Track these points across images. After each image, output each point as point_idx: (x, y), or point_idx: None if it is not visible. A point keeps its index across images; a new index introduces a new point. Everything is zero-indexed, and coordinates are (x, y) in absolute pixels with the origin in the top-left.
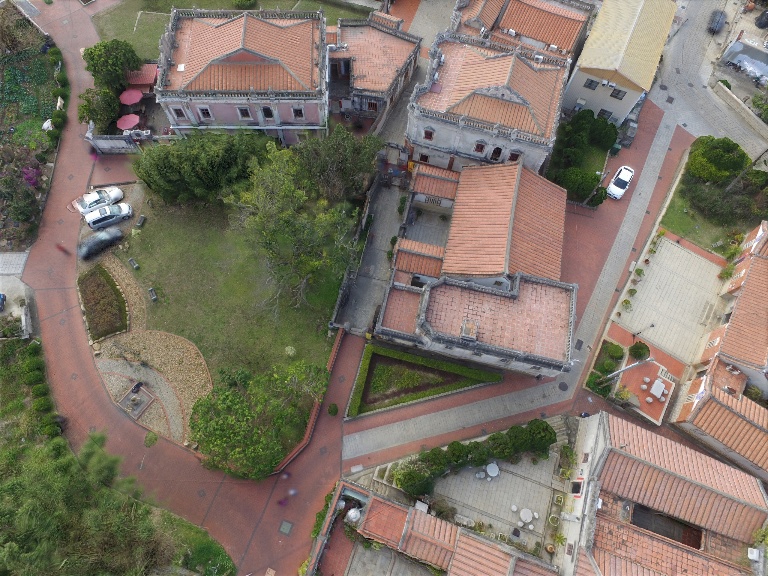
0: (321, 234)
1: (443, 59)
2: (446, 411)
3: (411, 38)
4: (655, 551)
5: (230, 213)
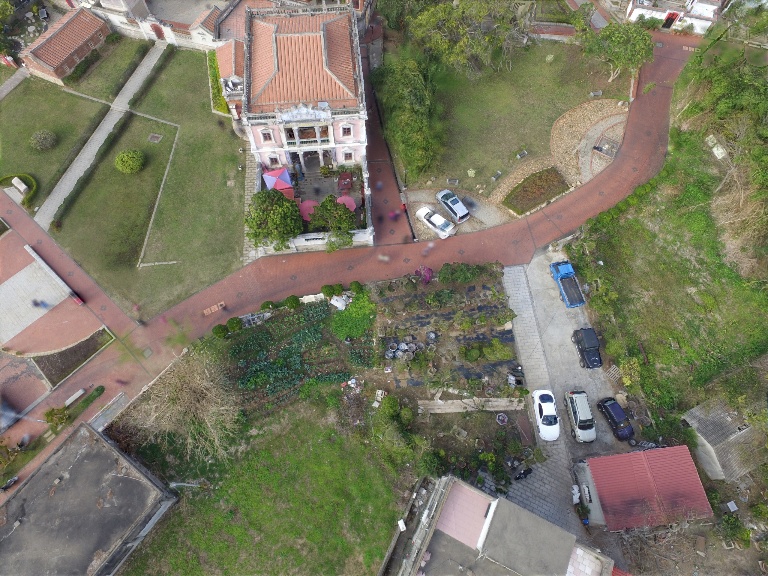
0: None
1: None
2: None
3: None
4: None
5: (434, 120)
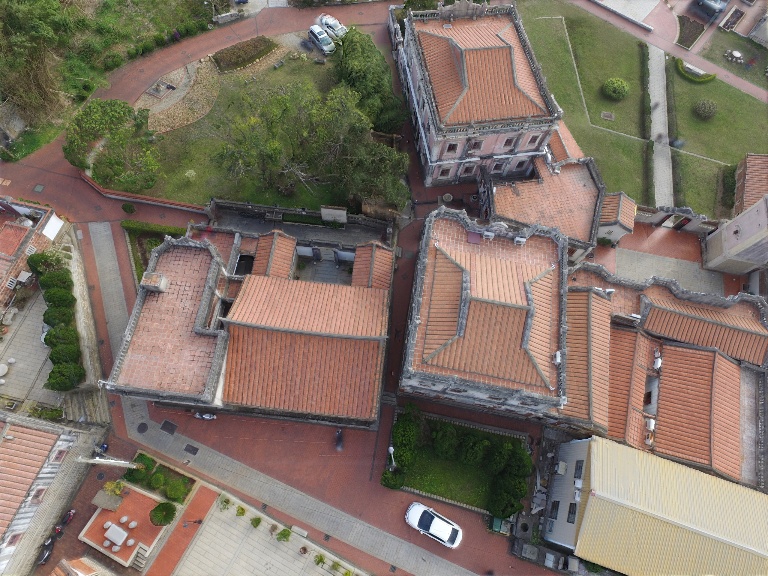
0: (262, 149)
1: (520, 241)
2: (125, 306)
3: (593, 236)
4: None
5: None
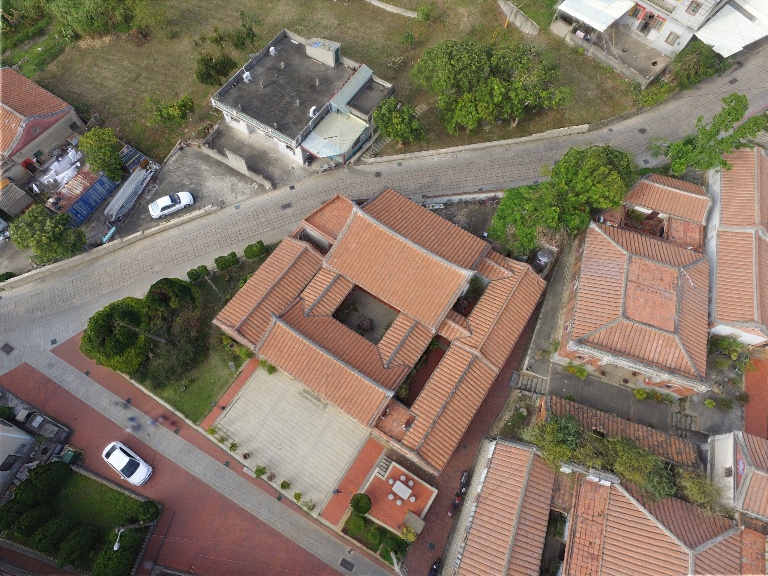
0: None
1: None
2: None
3: None
4: (580, 574)
5: None
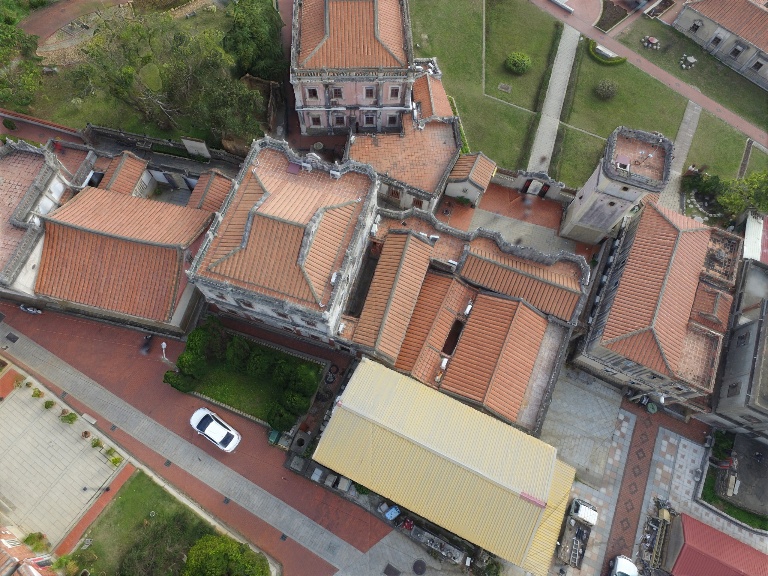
0: None
1: (334, 174)
2: None
3: None
4: None
5: None
